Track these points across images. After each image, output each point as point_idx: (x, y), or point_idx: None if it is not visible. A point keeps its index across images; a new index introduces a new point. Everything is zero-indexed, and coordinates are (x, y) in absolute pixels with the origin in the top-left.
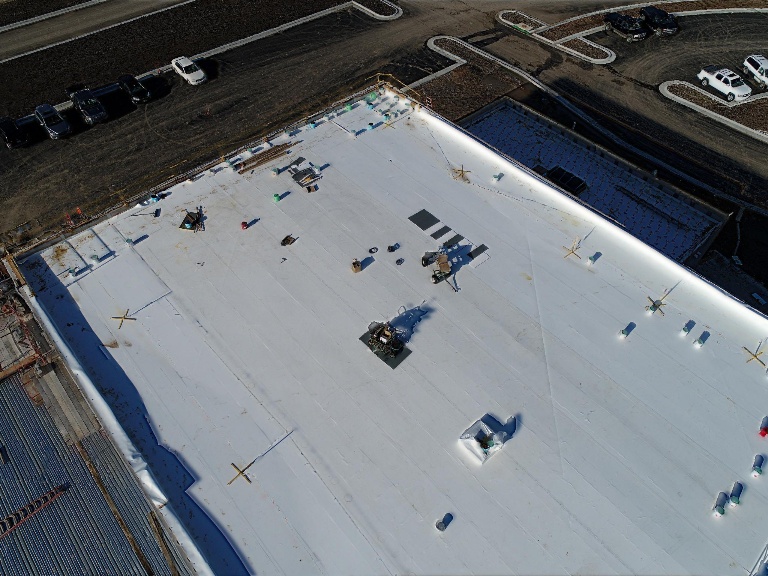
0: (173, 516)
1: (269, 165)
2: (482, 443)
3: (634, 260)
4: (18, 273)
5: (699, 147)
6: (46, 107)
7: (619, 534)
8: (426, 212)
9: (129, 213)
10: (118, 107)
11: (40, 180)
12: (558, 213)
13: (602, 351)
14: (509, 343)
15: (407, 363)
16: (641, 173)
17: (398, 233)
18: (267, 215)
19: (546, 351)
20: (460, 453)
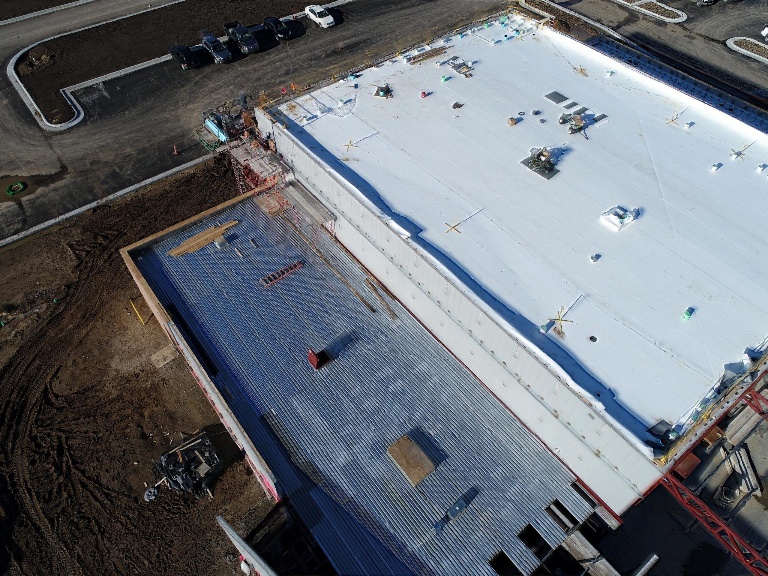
0: (416, 243)
1: (432, 60)
2: (619, 216)
3: (720, 128)
4: (269, 115)
5: (762, 88)
6: (212, 38)
7: (716, 269)
8: (557, 93)
9: (335, 85)
10: (265, 42)
11: (213, 92)
12: (659, 97)
13: (699, 177)
14: (630, 169)
15: (557, 177)
16: (717, 91)
17: (538, 104)
18: (438, 90)
19: (657, 175)
20: (602, 225)
